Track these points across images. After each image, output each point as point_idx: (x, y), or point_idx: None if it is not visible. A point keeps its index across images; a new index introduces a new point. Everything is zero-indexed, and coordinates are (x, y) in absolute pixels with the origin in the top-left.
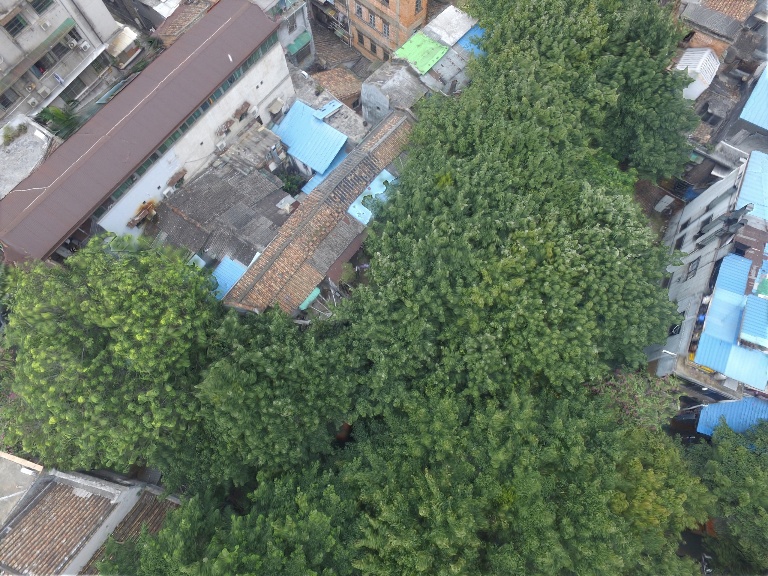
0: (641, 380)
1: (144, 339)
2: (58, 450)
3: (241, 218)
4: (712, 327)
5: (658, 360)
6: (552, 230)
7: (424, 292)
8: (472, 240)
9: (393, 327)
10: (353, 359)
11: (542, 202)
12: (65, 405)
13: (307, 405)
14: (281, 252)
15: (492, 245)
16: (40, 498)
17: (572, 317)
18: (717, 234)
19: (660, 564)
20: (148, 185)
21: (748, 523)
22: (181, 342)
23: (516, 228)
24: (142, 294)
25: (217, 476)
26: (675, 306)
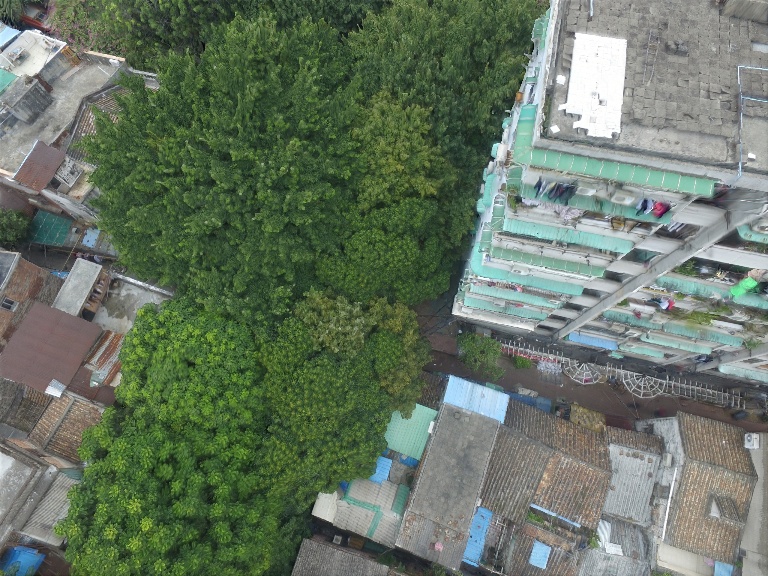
0: None
1: None
2: (143, 8)
3: None
4: None
5: None
6: None
7: None
8: None
9: None
10: None
11: None
12: None
13: None
14: None
15: None
16: None
17: None
18: None
19: None
20: None
21: None
22: None
23: None
24: None
25: None
26: None
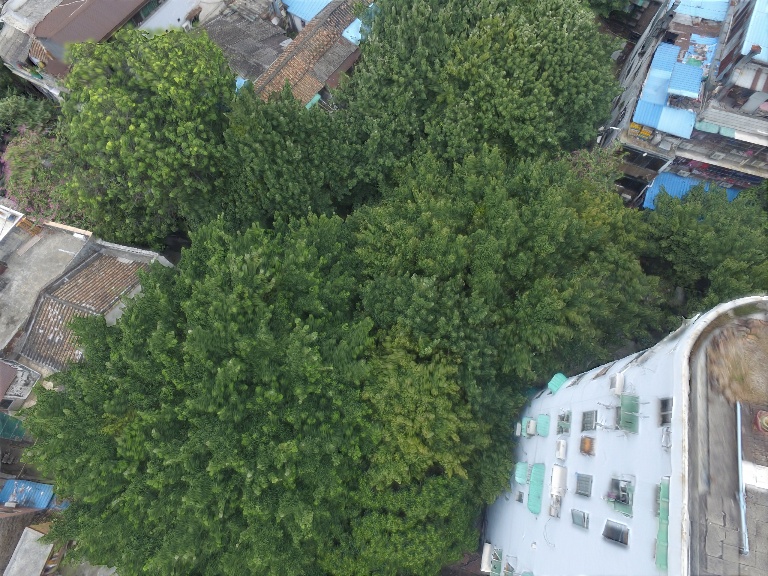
0: (593, 153)
1: (181, 82)
2: (110, 191)
3: (250, 48)
4: (647, 95)
5: (608, 145)
6: (513, 22)
7: (408, 67)
8: (447, 28)
9: (383, 103)
10: (351, 133)
11: (505, 8)
12: (119, 133)
13: (314, 167)
14: (286, 62)
15: (463, 33)
16: (90, 262)
17: (531, 87)
18: (653, 35)
19: (603, 253)
20: (170, 13)
21: (680, 250)
22: (209, 94)
23: (483, 17)
24: (177, 53)
25: (241, 217)
26: (617, 82)
